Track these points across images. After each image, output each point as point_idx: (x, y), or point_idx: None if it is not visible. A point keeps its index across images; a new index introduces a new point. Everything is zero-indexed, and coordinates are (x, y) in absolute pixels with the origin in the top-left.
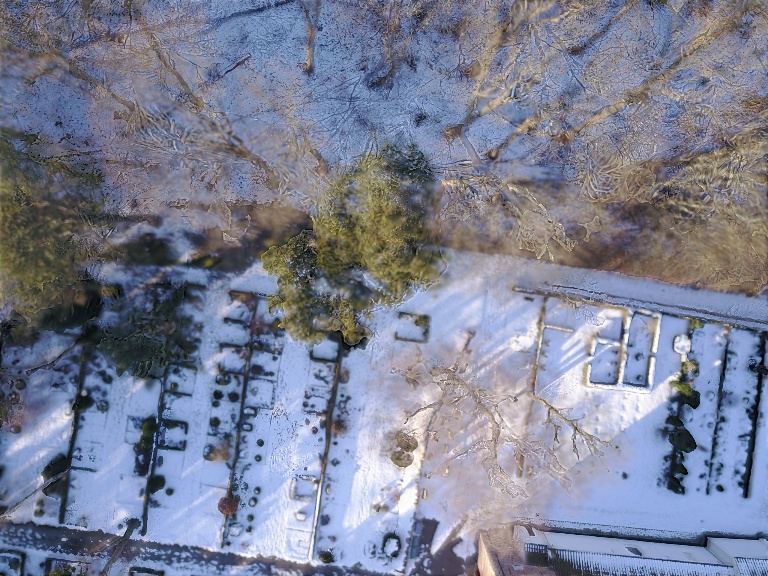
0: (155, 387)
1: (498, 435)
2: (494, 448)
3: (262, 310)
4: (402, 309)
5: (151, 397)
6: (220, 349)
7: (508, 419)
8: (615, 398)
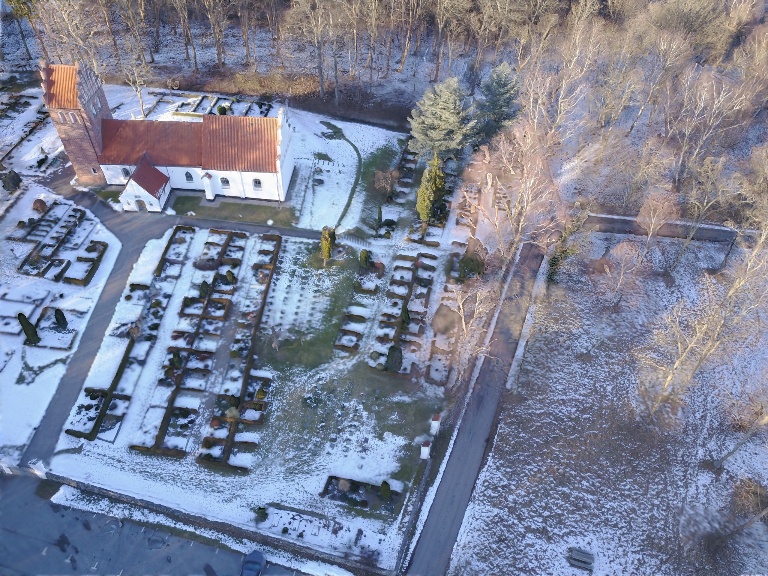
0: None
1: None
2: None
3: (22, 101)
4: None
5: None
6: None
7: None
8: None
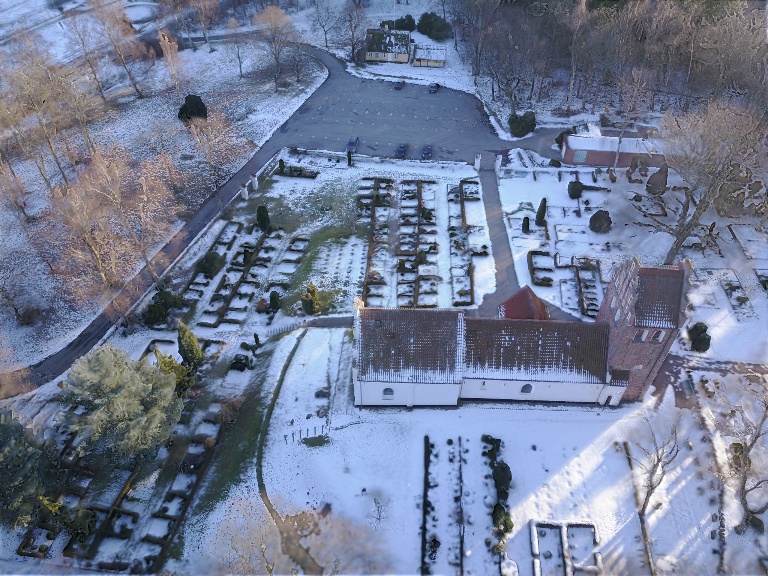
0: None
1: (755, 440)
2: (761, 428)
3: None
4: None
5: None
6: None
7: None
8: (561, 514)
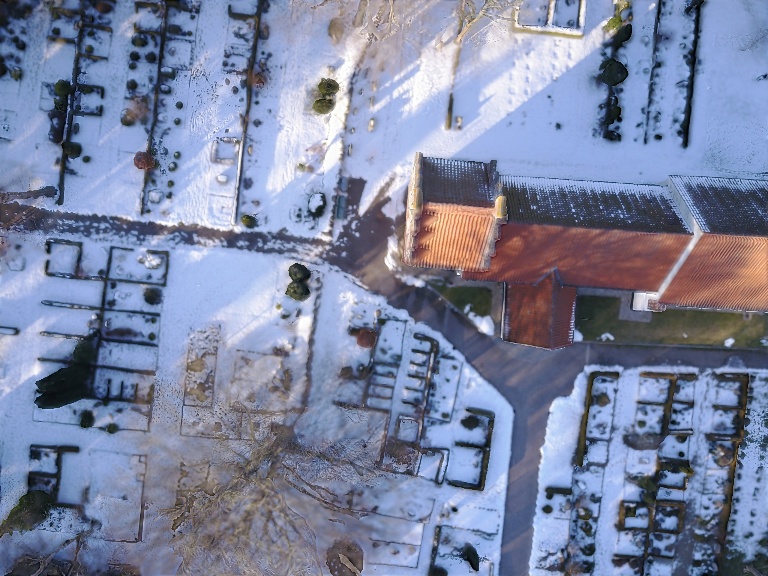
0: (70, 52)
1: None
2: None
3: None
4: None
5: (65, 62)
6: (135, 8)
7: (435, 69)
8: (546, 45)
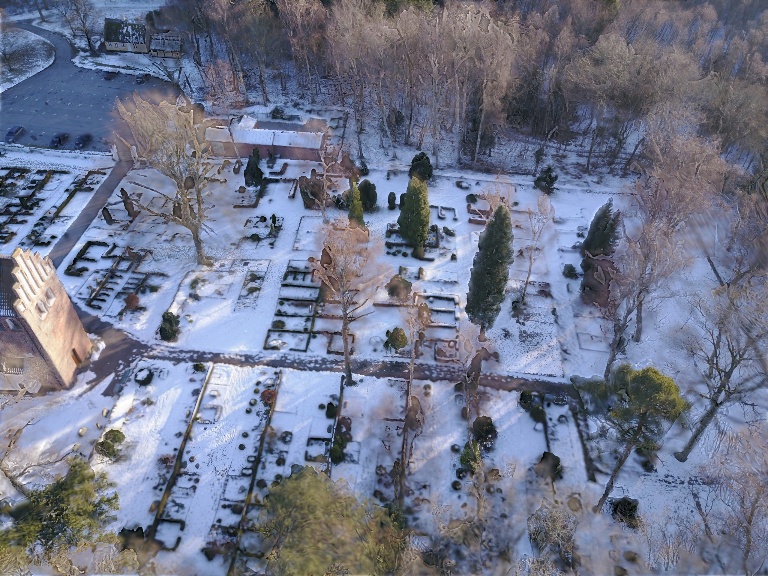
0: None
1: None
2: None
3: (225, 568)
4: (79, 575)
5: None
6: None
7: None
8: None
